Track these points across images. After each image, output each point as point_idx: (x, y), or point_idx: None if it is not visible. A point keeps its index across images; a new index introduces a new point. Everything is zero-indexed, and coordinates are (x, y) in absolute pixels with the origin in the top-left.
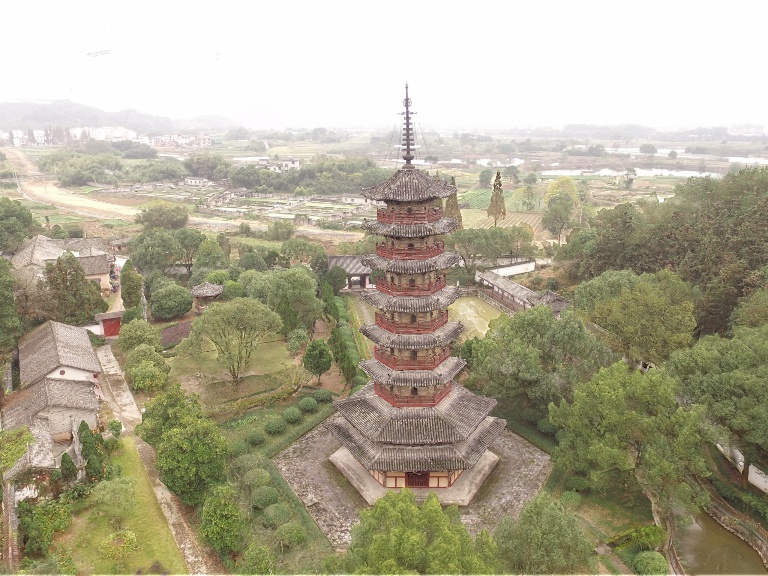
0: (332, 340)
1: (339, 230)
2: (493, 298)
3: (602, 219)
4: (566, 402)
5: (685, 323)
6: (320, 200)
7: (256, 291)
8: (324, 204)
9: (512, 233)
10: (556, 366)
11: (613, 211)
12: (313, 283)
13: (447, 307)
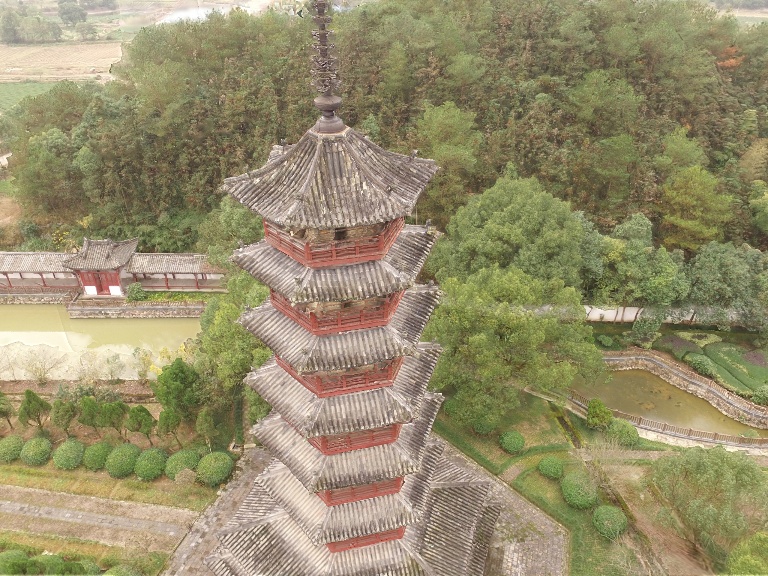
0: None
1: None
2: None
3: (33, 112)
4: None
5: None
6: None
7: None
8: None
9: None
10: None
11: (46, 97)
12: None
13: None
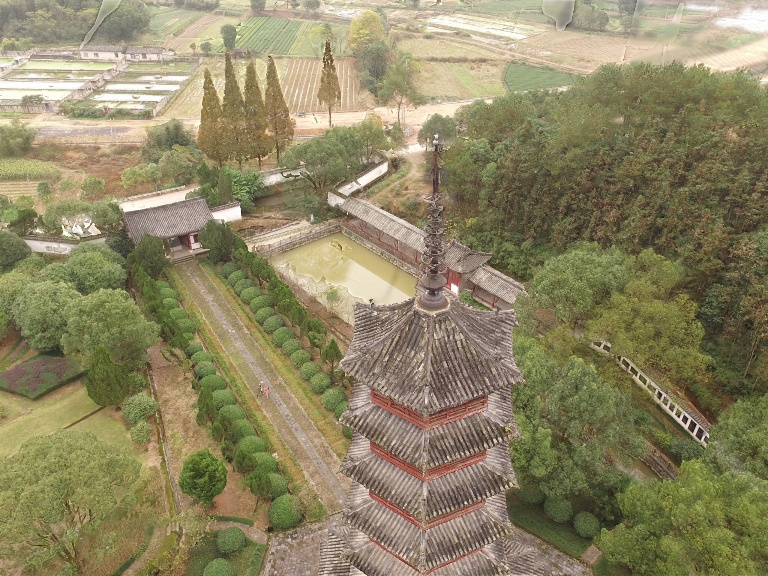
0: (204, 413)
1: (99, 119)
2: (368, 239)
3: (483, 118)
4: (625, 528)
5: (693, 333)
6: (46, 57)
7: (33, 323)
8: (54, 63)
9: (363, 134)
10: (572, 442)
11: (497, 108)
12: (136, 308)
13: (336, 292)
